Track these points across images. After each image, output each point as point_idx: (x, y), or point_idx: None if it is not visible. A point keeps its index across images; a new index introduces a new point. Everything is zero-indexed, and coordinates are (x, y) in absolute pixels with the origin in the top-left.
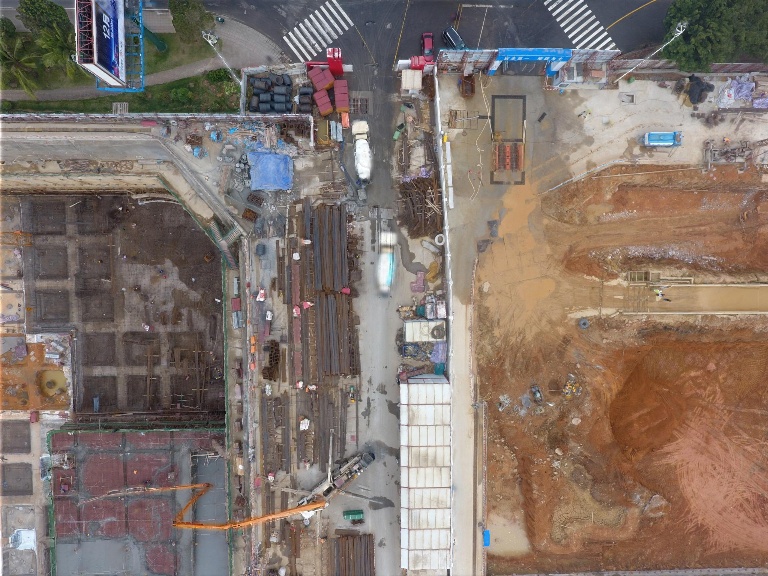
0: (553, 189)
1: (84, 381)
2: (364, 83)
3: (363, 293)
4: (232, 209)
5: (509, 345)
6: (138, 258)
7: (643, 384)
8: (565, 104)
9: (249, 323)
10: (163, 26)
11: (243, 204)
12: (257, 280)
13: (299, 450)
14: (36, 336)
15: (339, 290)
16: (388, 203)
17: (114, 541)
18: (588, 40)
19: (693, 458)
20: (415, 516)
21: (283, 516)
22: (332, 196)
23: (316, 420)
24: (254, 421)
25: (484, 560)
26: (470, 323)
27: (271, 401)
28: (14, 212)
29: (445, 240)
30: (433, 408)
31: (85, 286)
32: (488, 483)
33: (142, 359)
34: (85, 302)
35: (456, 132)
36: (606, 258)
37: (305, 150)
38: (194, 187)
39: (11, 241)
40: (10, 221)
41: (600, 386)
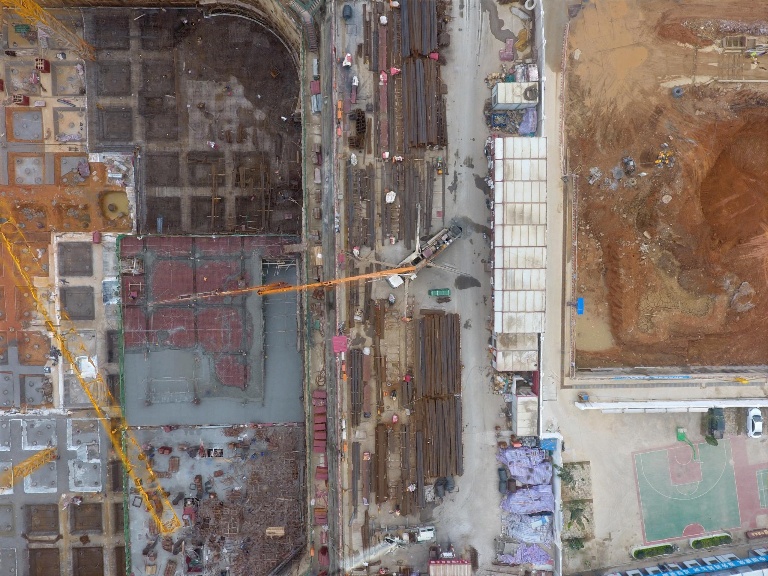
0: None
1: (148, 201)
2: None
3: (451, 61)
4: None
5: (600, 115)
6: (203, 73)
7: (732, 168)
8: None
9: (335, 90)
10: None
11: None
12: (343, 46)
13: (384, 226)
14: (99, 155)
15: (428, 54)
16: None
17: (183, 351)
18: None
19: None
20: (510, 276)
21: (374, 277)
22: None
23: (402, 194)
24: (339, 193)
25: (573, 340)
26: (560, 91)
27: (356, 172)
28: (76, 27)
29: (537, 2)
30: (529, 163)
31: (148, 106)
32: None
33: (207, 178)
34: (148, 121)
35: None
36: (698, 28)
37: None
38: None
39: (78, 44)
40: None
41: (691, 162)
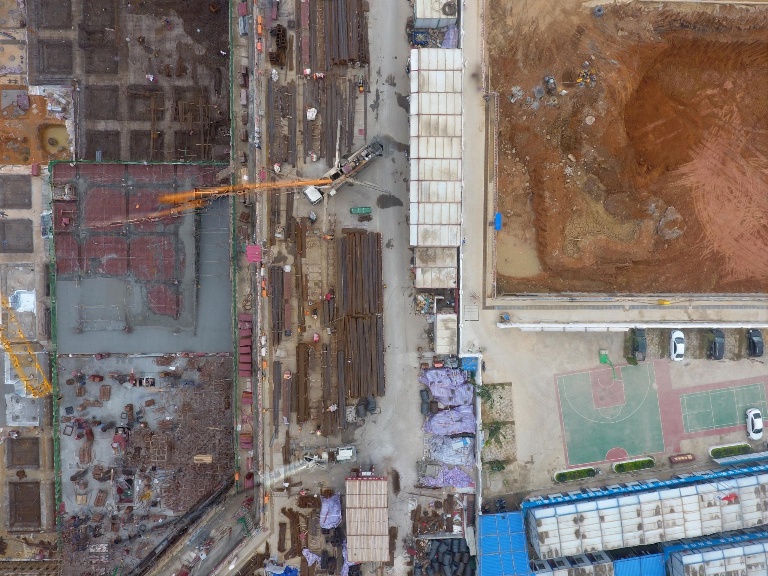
0: None
1: (87, 134)
2: None
3: None
4: None
5: (522, 34)
6: (143, 7)
7: (658, 92)
8: None
9: (256, 5)
10: None
11: None
12: None
13: (306, 143)
14: (38, 88)
15: None
16: None
17: (115, 279)
18: None
19: (709, 180)
20: (425, 188)
21: (289, 188)
22: None
23: (323, 111)
24: (260, 110)
25: (495, 259)
26: (482, 9)
27: (278, 88)
28: None
29: None
30: (444, 74)
31: None
32: (499, 197)
33: (146, 112)
34: (88, 55)
35: None
36: None
37: None
38: None
39: None
40: None
41: (615, 83)
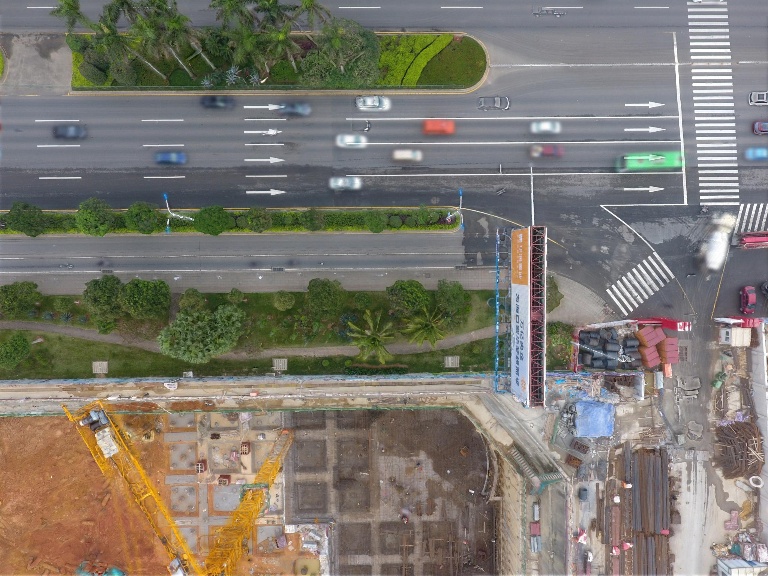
0: None
1: (341, 571)
2: (683, 332)
3: (678, 532)
4: (555, 454)
5: None
6: (396, 452)
7: None
8: None
9: None
10: (494, 283)
11: (569, 452)
12: (576, 521)
13: None
14: (294, 526)
15: (660, 533)
16: (704, 445)
17: None
18: None
19: None
20: None
21: None
22: (652, 441)
23: None
24: None
25: None
26: None
27: None
28: None
29: (764, 484)
30: None
31: (339, 475)
32: None
33: (398, 549)
34: (341, 492)
35: None
36: None
37: (627, 398)
38: (506, 424)
39: (288, 447)
40: (270, 415)
41: None
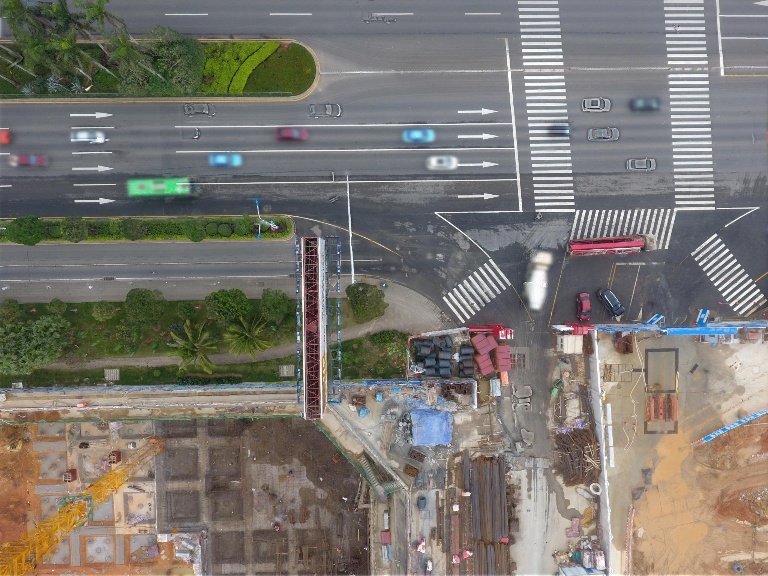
0: (706, 439)
1: None
2: (521, 339)
3: (519, 540)
4: (393, 463)
5: None
6: (267, 459)
7: None
8: (716, 355)
9: None
10: None
11: (405, 460)
12: (417, 530)
13: None
14: (167, 535)
15: (499, 541)
16: (544, 453)
17: None
18: (737, 292)
19: None
20: None
21: None
22: (490, 448)
23: None
24: None
25: None
26: (625, 569)
27: None
28: None
29: (602, 491)
30: None
31: (213, 483)
32: None
33: (271, 557)
34: (214, 501)
35: (611, 385)
36: (756, 499)
37: (464, 405)
38: (350, 433)
39: (151, 456)
40: (142, 423)
41: None
